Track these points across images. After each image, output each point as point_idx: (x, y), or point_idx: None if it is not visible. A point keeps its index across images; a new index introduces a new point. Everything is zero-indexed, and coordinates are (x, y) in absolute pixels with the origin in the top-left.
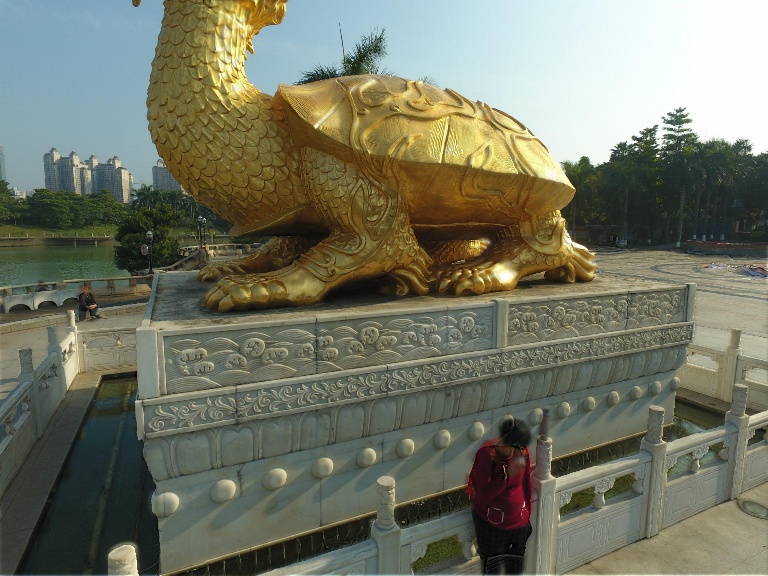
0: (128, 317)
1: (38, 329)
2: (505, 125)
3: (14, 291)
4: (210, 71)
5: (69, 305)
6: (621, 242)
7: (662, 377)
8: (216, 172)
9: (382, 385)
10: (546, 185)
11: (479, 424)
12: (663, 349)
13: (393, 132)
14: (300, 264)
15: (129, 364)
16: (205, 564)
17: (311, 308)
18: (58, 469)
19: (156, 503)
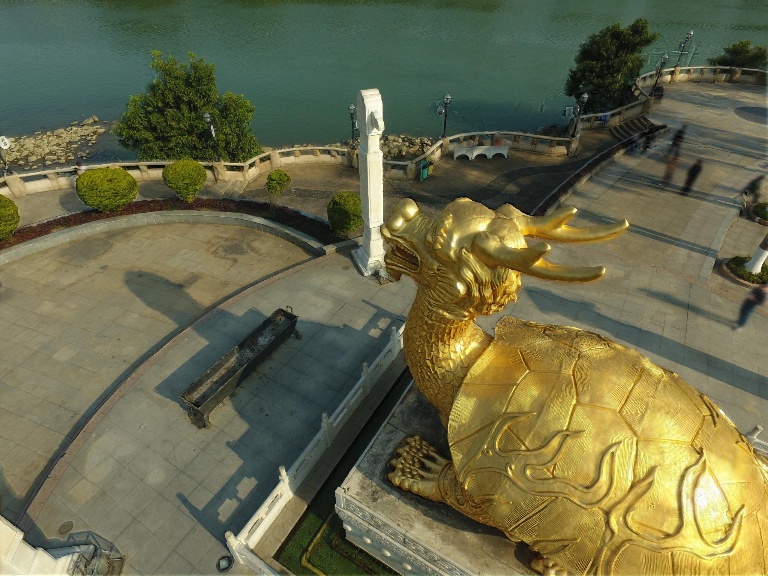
0: None
1: None
2: (631, 527)
3: (465, 138)
4: (426, 350)
5: (495, 159)
6: None
7: None
8: (423, 392)
9: (435, 574)
10: None
11: None
12: None
13: (491, 486)
14: (437, 478)
15: None
16: (359, 547)
17: (428, 507)
18: (359, 430)
19: (343, 526)
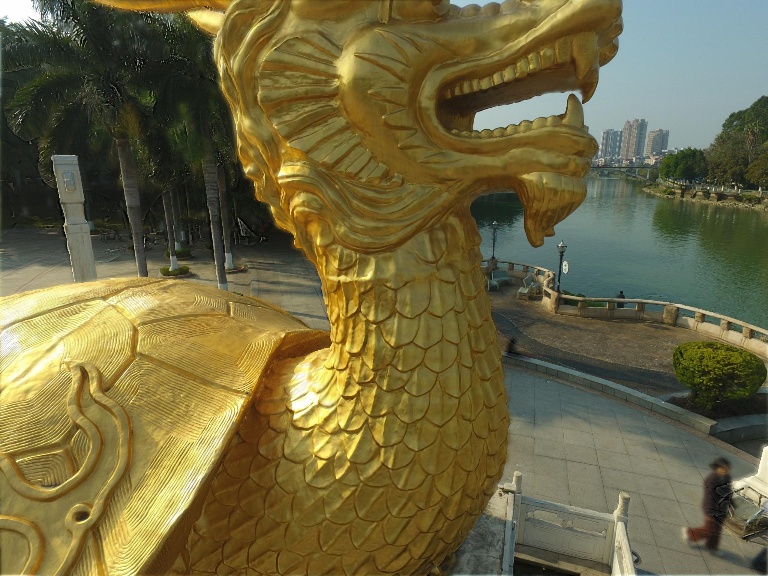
0: None
1: None
2: None
3: None
4: None
5: None
6: None
7: None
8: None
9: None
10: None
11: None
12: None
13: None
14: None
15: None
16: None
17: None
18: None
19: None
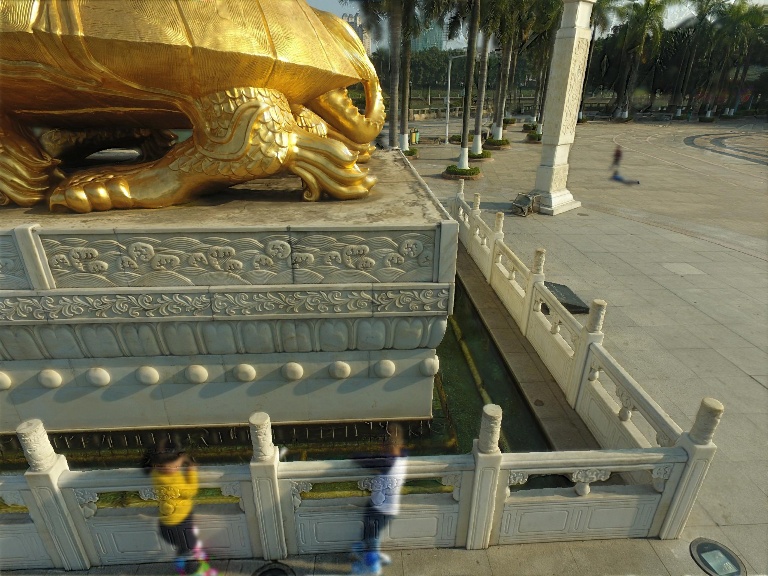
0: None
1: None
2: None
3: None
4: None
5: None
6: None
7: (399, 355)
8: None
9: None
10: (116, 48)
11: (48, 372)
12: (383, 318)
13: None
14: None
15: None
16: None
17: None
18: None
19: None
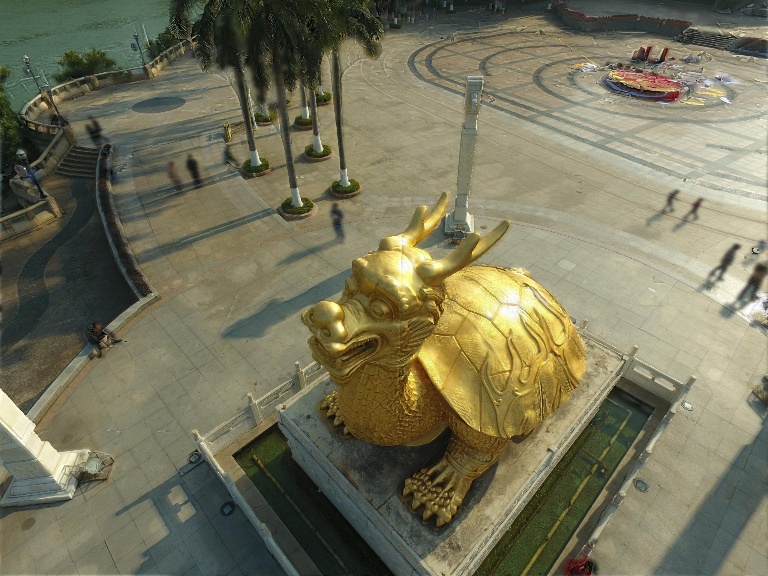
0: (139, 333)
1: (77, 383)
2: (559, 344)
3: None
4: (402, 405)
5: None
6: (499, 10)
7: None
8: None
9: (510, 519)
10: None
11: None
12: None
13: (519, 414)
14: (460, 474)
15: (241, 435)
16: None
17: (472, 497)
18: (320, 573)
19: None
